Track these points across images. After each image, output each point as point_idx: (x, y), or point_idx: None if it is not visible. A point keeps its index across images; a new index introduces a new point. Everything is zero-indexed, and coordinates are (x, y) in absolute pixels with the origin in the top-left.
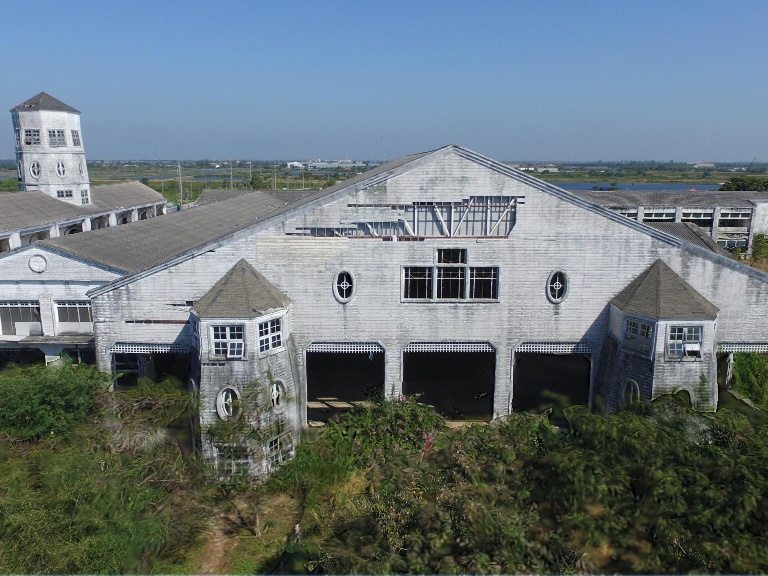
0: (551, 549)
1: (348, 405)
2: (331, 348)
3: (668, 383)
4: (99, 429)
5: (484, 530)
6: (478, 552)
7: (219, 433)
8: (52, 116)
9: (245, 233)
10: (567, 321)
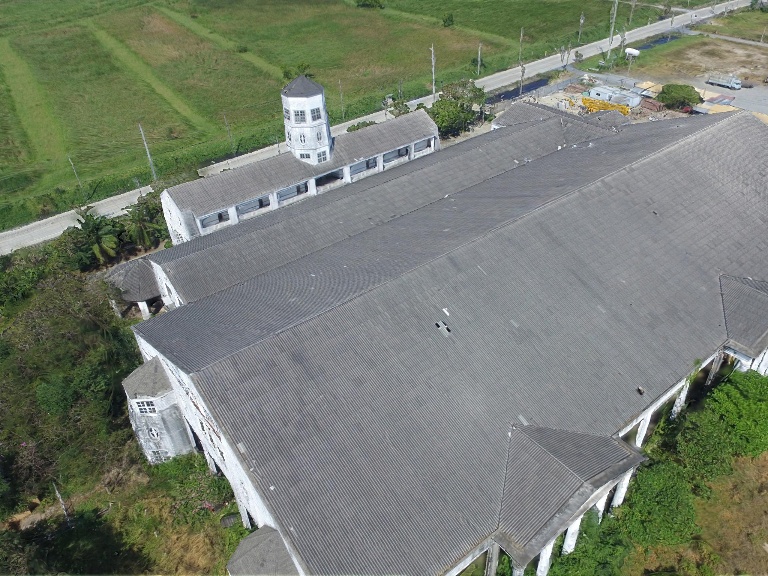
0: None
1: None
2: None
3: None
4: None
5: None
6: None
7: None
8: (297, 101)
9: None
10: None
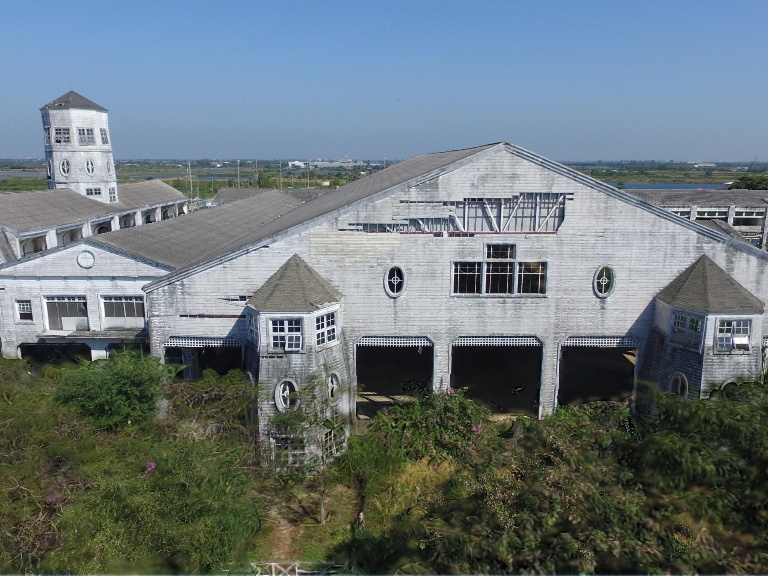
0: (664, 526)
1: (388, 399)
2: (381, 342)
3: (717, 376)
4: (175, 419)
5: (594, 509)
6: (593, 529)
7: (291, 423)
8: (82, 115)
9: (299, 229)
10: (613, 315)
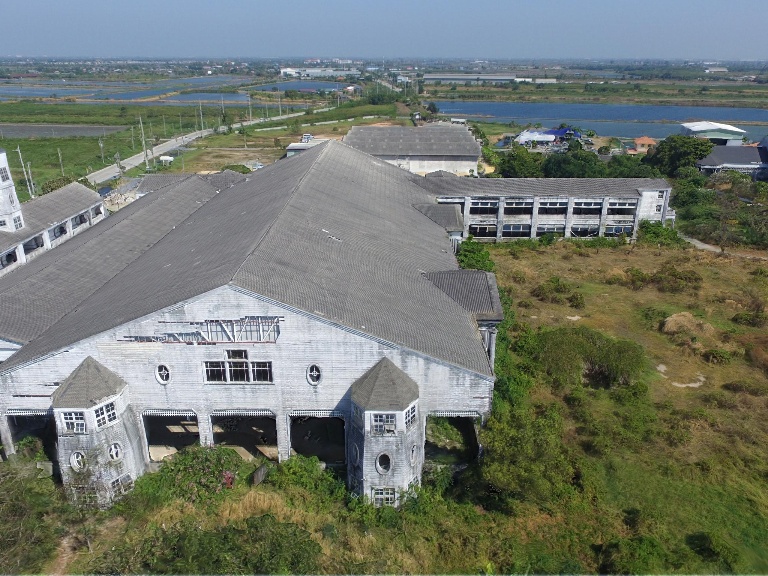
0: None
1: None
2: (160, 413)
3: (374, 450)
4: None
5: None
6: None
7: None
8: None
9: (88, 340)
10: (324, 396)
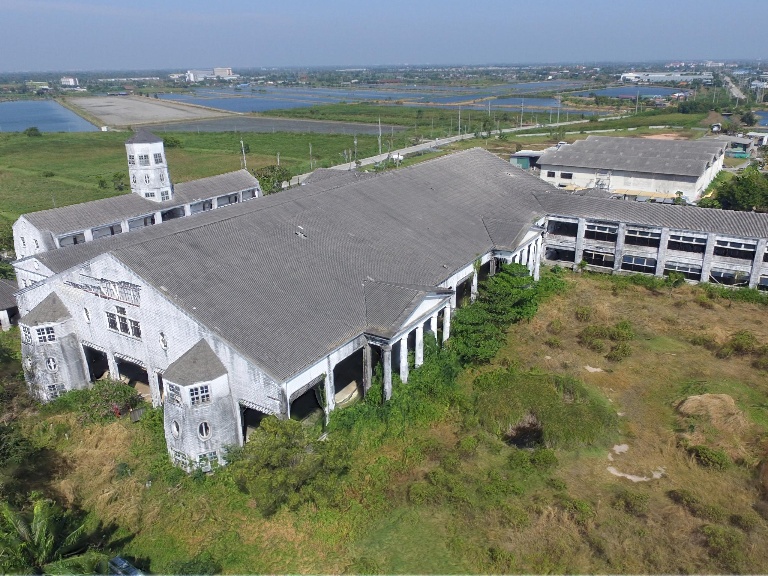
0: None
1: None
2: (90, 345)
3: (170, 414)
4: None
5: None
6: None
7: None
8: (141, 146)
9: (51, 279)
10: None
